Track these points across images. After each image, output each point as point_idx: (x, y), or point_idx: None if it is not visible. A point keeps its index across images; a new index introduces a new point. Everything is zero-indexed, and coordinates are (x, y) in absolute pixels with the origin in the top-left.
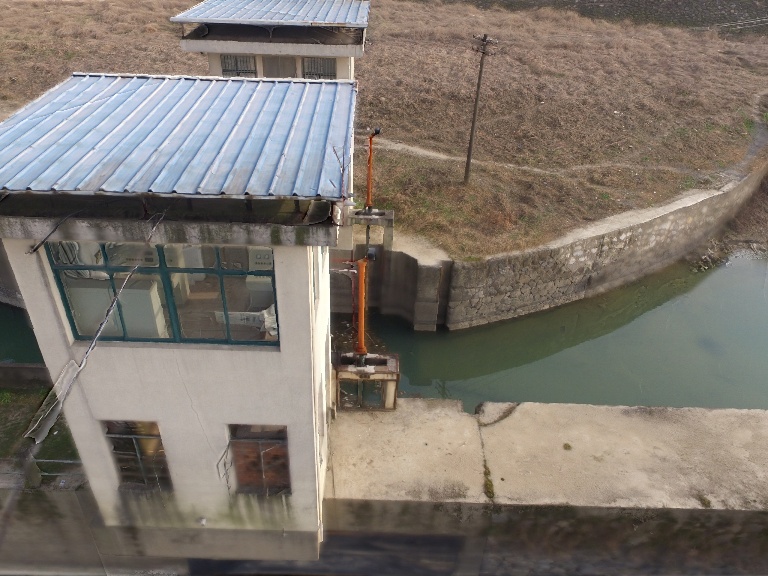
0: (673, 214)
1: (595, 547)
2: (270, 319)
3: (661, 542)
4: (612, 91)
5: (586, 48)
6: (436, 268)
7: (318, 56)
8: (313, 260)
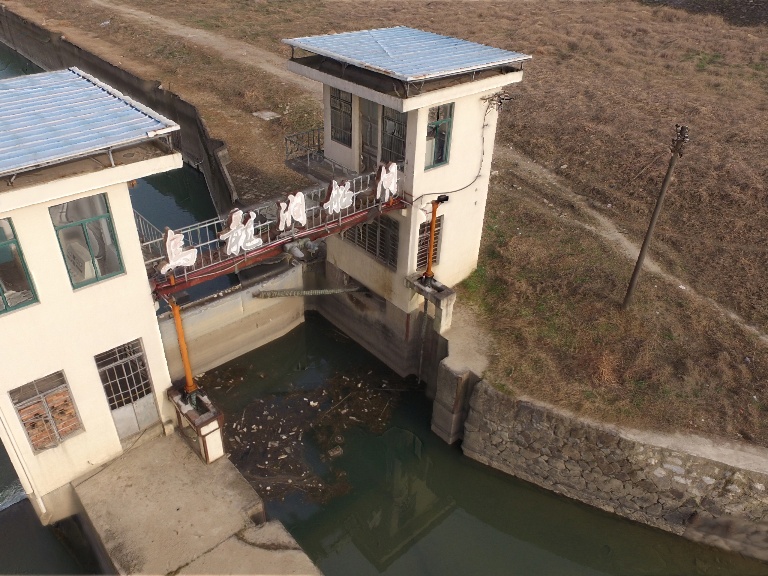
0: None
1: None
2: (1, 298)
3: None
4: None
5: None
6: (454, 374)
7: None
8: (26, 266)
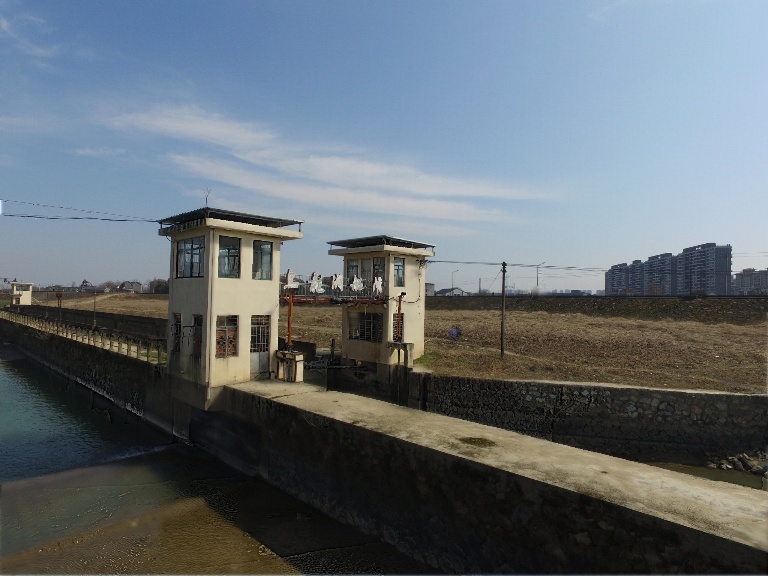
0: (660, 393)
1: (308, 453)
2: None
3: (336, 457)
4: (739, 350)
5: (767, 336)
6: (417, 373)
7: (379, 256)
8: (240, 261)
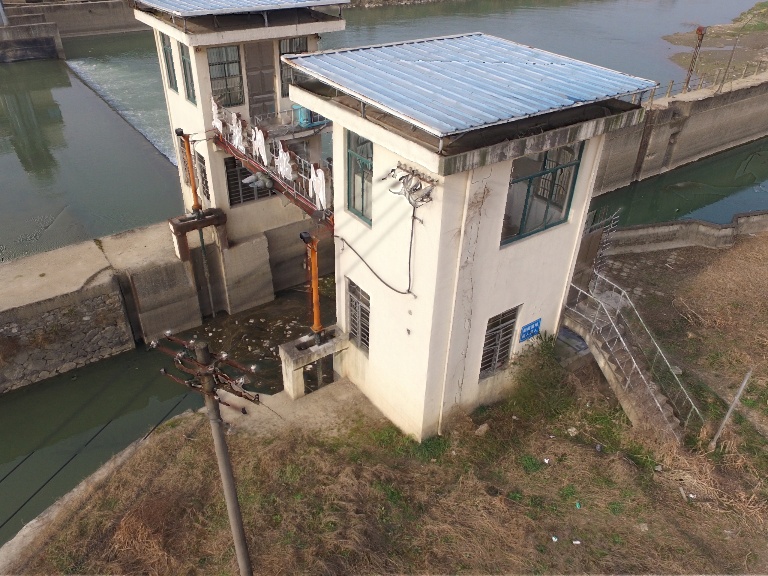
0: None
1: None
2: None
3: None
4: None
5: None
6: None
7: None
8: None
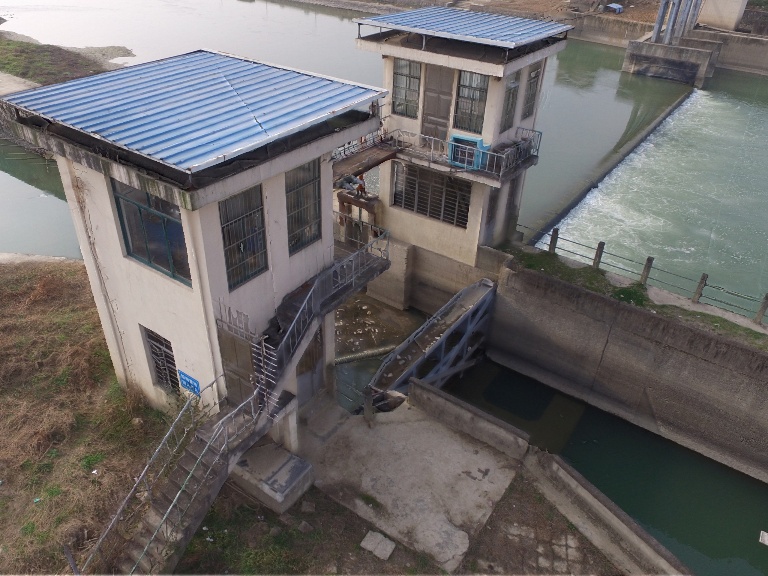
0: None
1: None
2: None
3: None
4: None
5: None
6: None
7: None
8: None
